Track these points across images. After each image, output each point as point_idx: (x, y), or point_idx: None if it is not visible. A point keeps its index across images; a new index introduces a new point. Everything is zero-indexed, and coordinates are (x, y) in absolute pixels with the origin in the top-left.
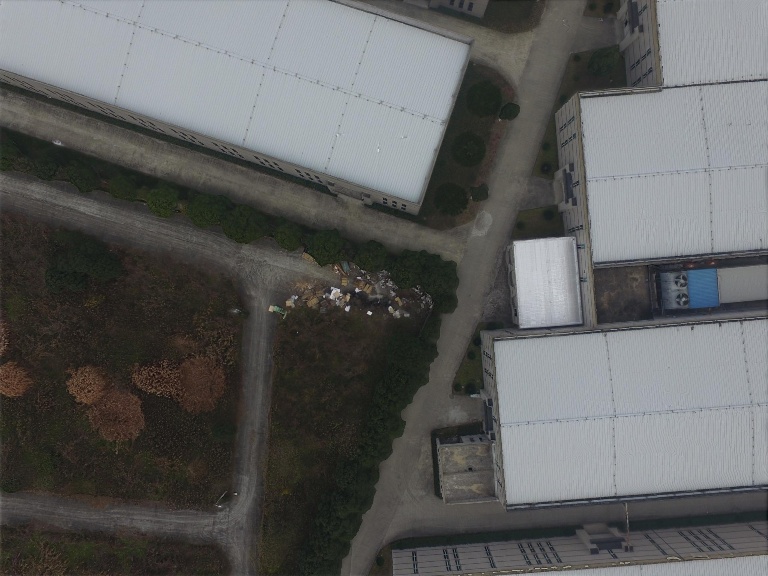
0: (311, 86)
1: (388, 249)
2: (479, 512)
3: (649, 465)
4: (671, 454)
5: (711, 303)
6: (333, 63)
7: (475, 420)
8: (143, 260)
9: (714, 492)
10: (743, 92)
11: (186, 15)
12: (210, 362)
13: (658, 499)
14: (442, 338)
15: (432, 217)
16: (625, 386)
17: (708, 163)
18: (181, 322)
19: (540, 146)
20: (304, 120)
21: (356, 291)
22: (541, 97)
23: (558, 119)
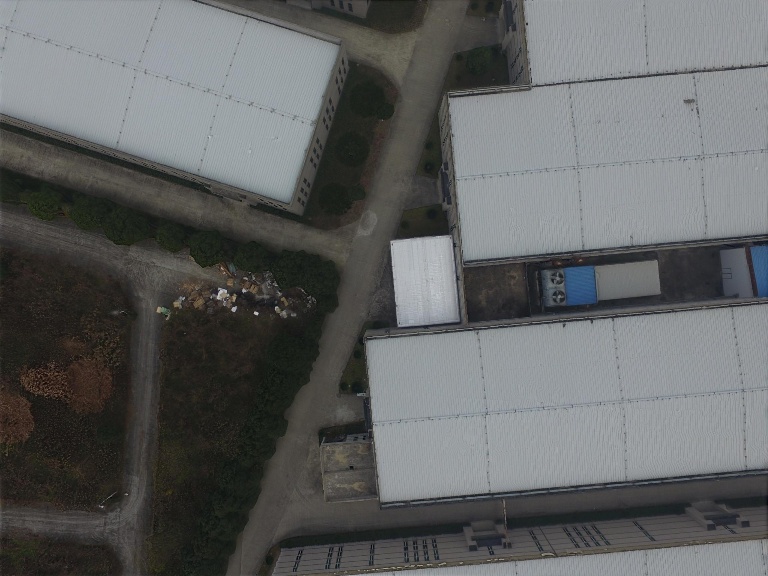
0: (182, 88)
1: (274, 249)
2: (367, 510)
3: (524, 462)
4: (546, 451)
5: (589, 300)
6: (204, 65)
7: (362, 419)
8: (30, 263)
9: (587, 488)
10: (612, 90)
11: (58, 19)
12: (98, 363)
13: (531, 496)
14: (329, 337)
15: (317, 217)
16: (497, 383)
17: (577, 161)
18: (69, 324)
19: (424, 145)
20: (176, 122)
21: (243, 291)
22: (424, 97)
23: (440, 118)
